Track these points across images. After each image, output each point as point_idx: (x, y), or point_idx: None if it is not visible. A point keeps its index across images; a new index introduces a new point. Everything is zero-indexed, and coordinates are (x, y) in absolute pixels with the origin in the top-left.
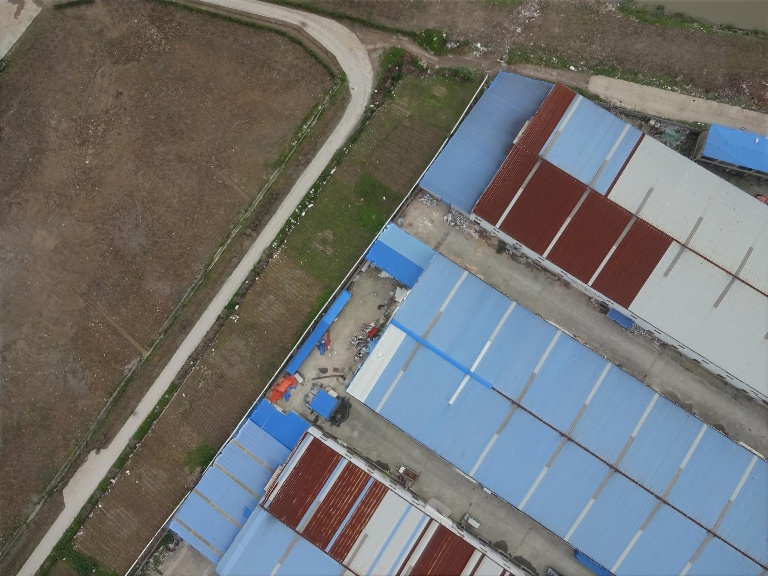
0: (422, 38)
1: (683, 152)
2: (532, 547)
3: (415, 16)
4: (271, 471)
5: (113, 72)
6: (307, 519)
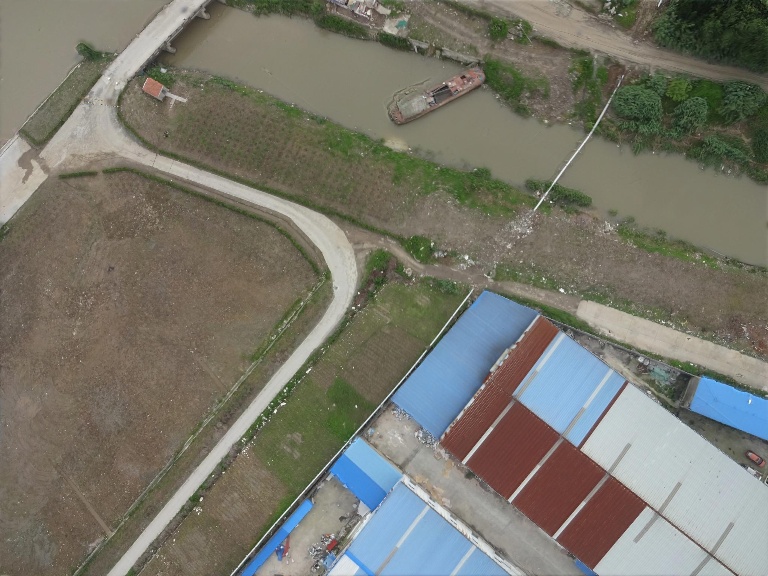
0: (409, 245)
1: (672, 393)
2: None
3: (405, 219)
4: None
5: (107, 246)
6: None
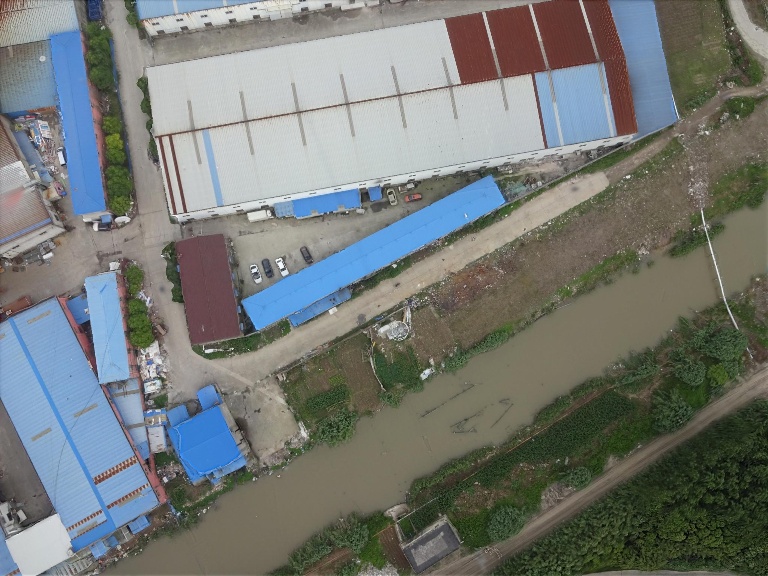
0: (750, 101)
1: (498, 185)
2: None
3: None
4: None
5: None
6: None
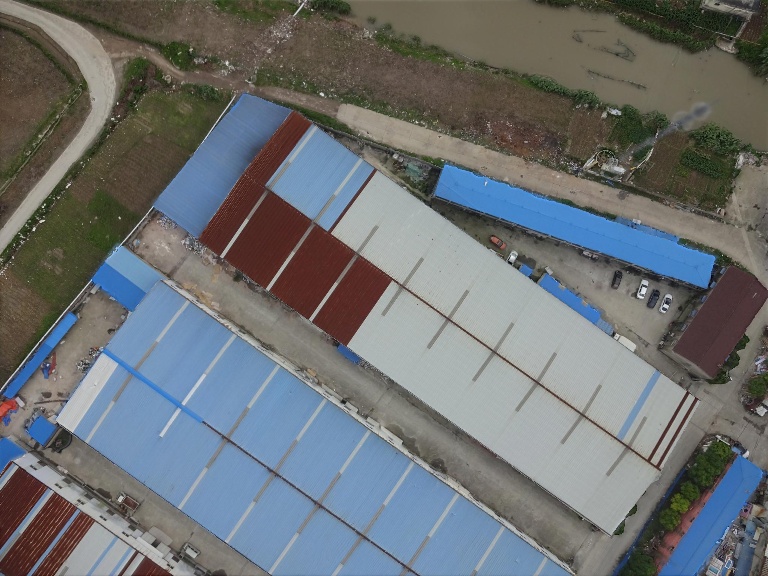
0: (167, 51)
1: (425, 188)
2: (251, 575)
3: (163, 26)
4: None
5: None
6: (4, 552)
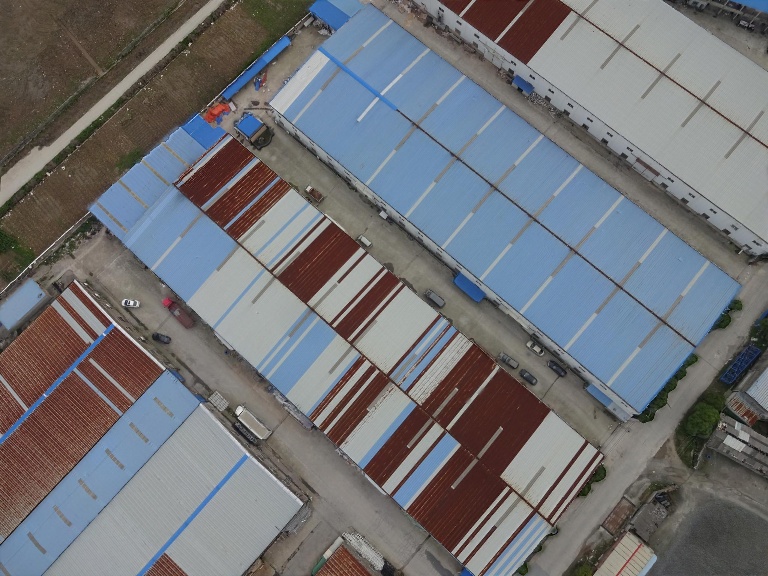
0: None
1: None
2: (416, 272)
3: None
4: None
5: None
6: (213, 201)
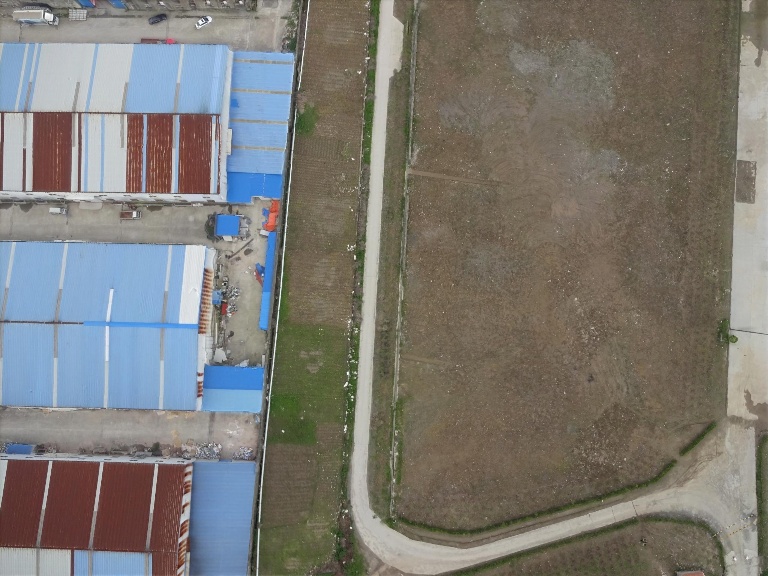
0: None
1: None
2: (2, 221)
3: None
4: (235, 146)
5: (612, 396)
6: (175, 128)
